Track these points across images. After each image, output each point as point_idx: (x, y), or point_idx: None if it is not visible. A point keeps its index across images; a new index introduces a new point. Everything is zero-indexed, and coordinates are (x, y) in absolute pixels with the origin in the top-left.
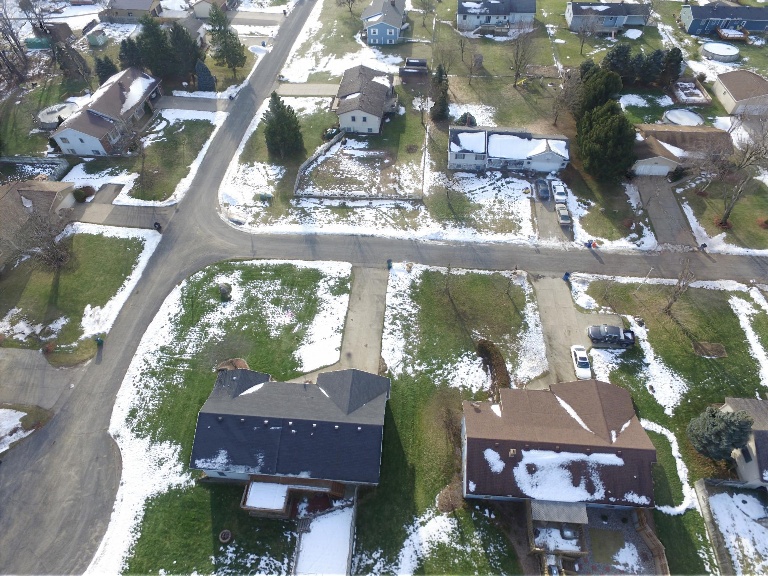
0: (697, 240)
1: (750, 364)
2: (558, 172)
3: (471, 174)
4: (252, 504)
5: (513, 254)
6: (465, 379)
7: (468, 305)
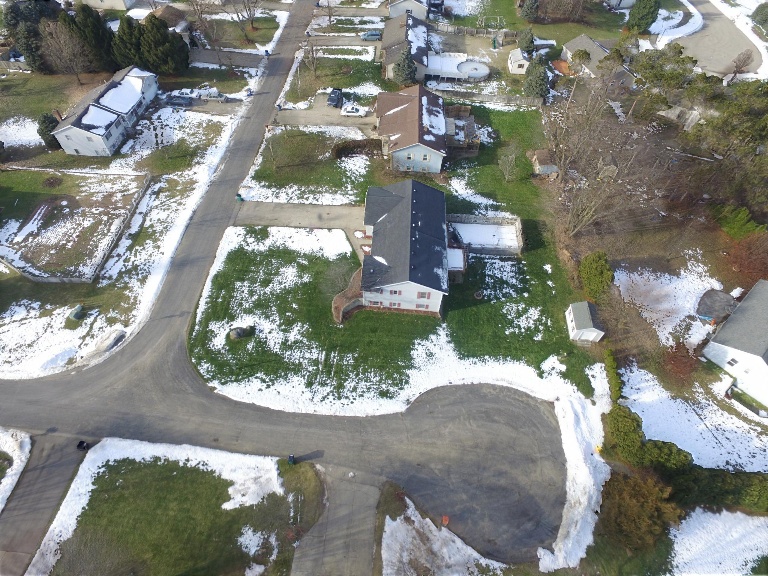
0: (259, 54)
1: (357, 61)
2: (160, 90)
3: (129, 142)
4: (462, 266)
5: (248, 129)
6: (360, 166)
7: (295, 158)
